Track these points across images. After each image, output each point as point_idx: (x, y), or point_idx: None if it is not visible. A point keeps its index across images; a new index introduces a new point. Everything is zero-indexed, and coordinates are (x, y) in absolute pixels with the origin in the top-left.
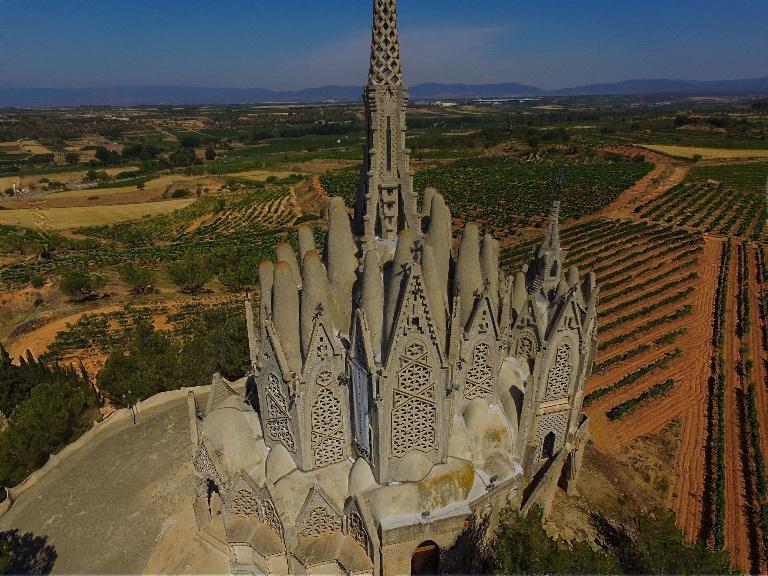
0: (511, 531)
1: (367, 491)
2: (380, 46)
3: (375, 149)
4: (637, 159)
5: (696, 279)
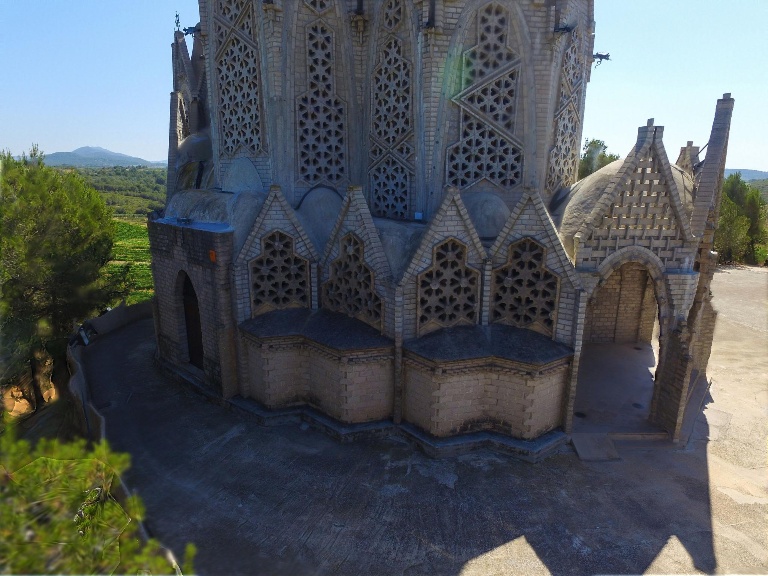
0: None
1: None
2: None
3: None
4: None
5: None
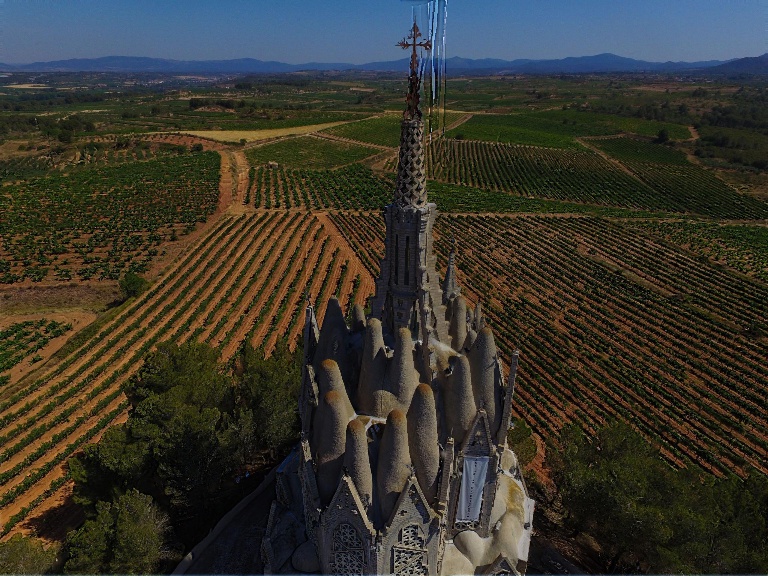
0: (581, 487)
1: (489, 550)
2: (420, 172)
3: (424, 265)
4: (196, 148)
5: (340, 252)
